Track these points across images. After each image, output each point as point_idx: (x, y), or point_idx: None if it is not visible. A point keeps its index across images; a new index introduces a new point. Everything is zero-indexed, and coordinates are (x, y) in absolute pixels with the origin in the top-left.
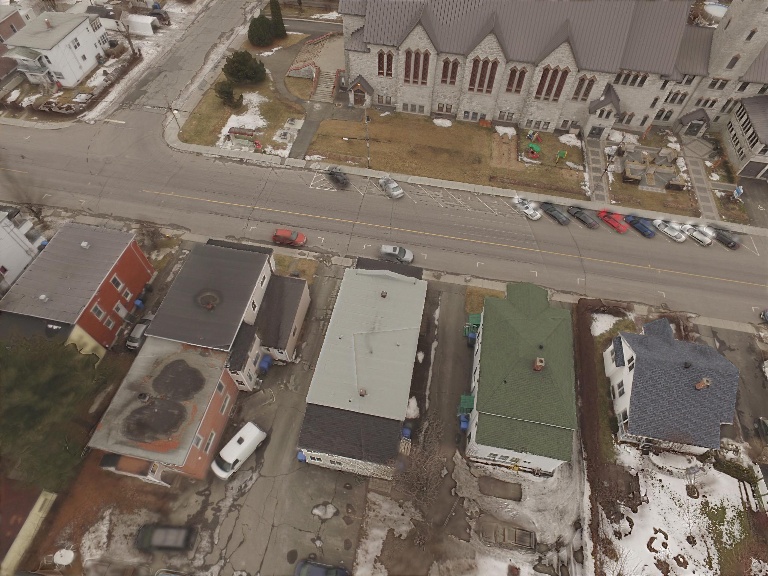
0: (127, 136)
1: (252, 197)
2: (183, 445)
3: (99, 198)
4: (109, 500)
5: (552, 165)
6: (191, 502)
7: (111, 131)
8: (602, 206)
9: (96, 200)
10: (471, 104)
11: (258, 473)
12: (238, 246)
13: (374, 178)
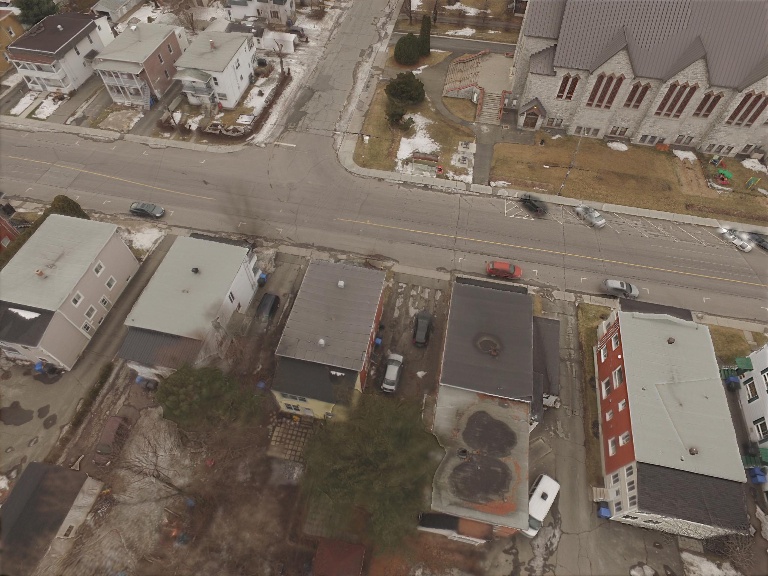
0: (302, 160)
1: (450, 226)
2: (520, 507)
3: (296, 227)
4: (416, 558)
5: (745, 192)
6: (502, 561)
7: (285, 155)
8: None
9: (293, 229)
10: (652, 128)
11: (559, 530)
12: (491, 285)
13: (567, 206)
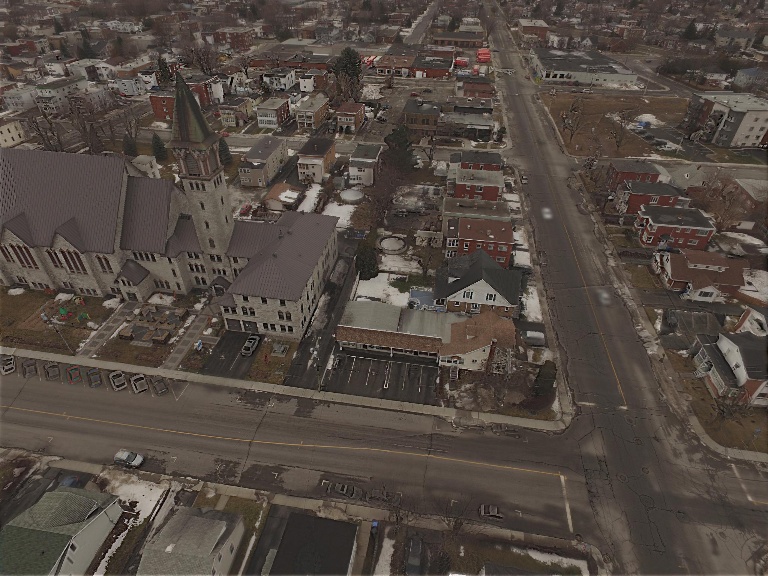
0: None
1: None
2: None
3: None
4: None
5: (72, 325)
6: None
7: None
8: (80, 360)
9: None
10: (32, 277)
11: None
12: None
13: None
